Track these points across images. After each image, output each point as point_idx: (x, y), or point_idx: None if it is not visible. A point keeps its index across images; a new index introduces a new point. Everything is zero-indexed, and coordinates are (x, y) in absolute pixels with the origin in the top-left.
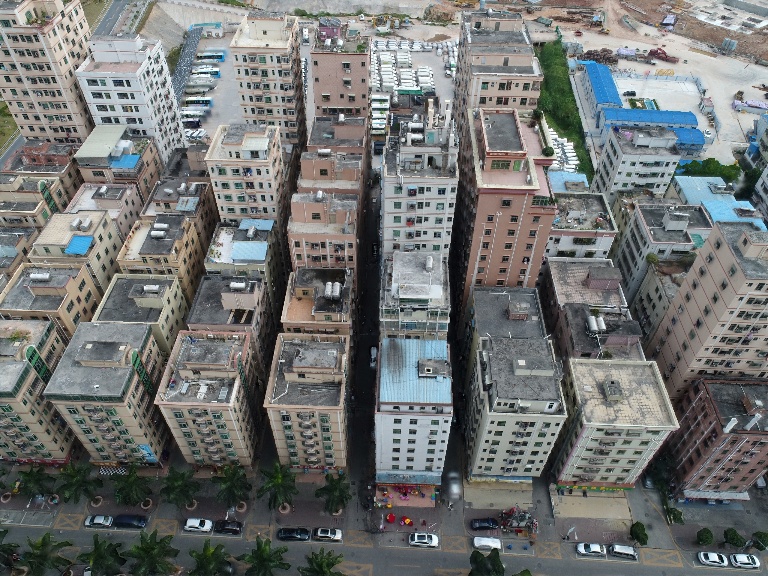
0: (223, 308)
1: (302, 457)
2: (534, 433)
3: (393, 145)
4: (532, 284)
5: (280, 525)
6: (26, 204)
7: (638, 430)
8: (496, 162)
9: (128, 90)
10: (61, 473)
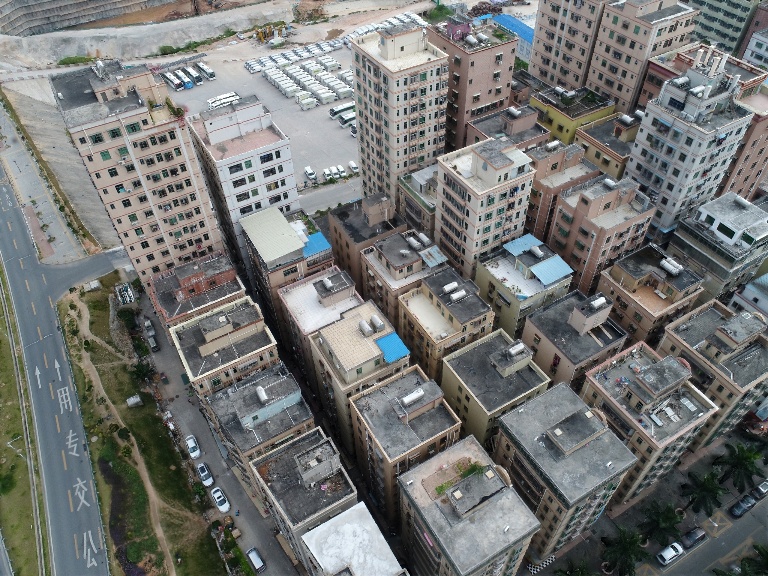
0: (579, 335)
1: None
2: None
3: None
4: (752, 195)
5: (723, 507)
6: (246, 341)
7: None
8: (745, 92)
9: (276, 163)
10: None
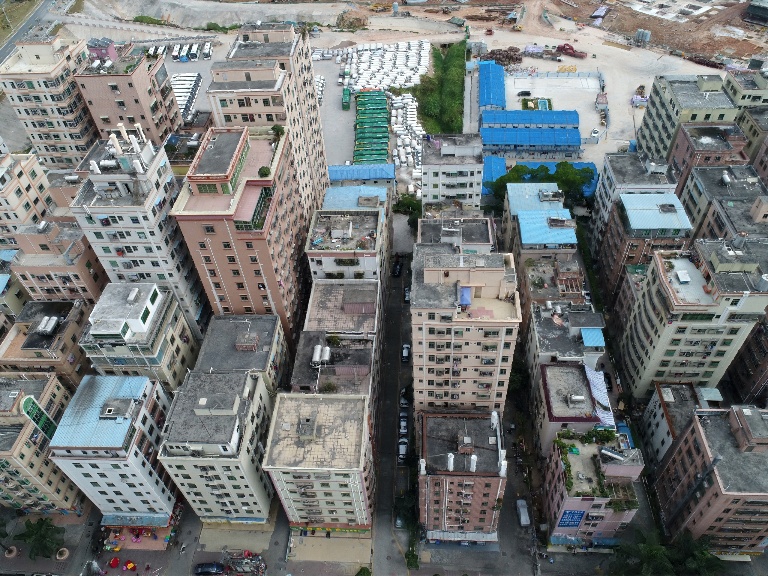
0: None
1: (19, 500)
2: (222, 476)
3: None
4: (281, 310)
5: (2, 570)
6: None
7: (323, 473)
8: (202, 186)
9: None
10: None
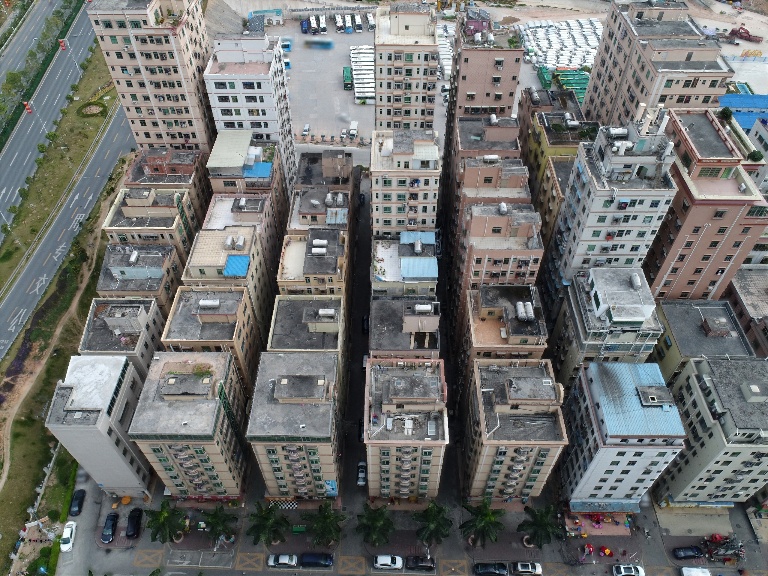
0: (402, 331)
1: (497, 488)
2: (765, 462)
3: (587, 152)
4: (718, 295)
5: None
6: (160, 219)
7: None
8: (705, 169)
9: (258, 93)
10: (253, 515)
